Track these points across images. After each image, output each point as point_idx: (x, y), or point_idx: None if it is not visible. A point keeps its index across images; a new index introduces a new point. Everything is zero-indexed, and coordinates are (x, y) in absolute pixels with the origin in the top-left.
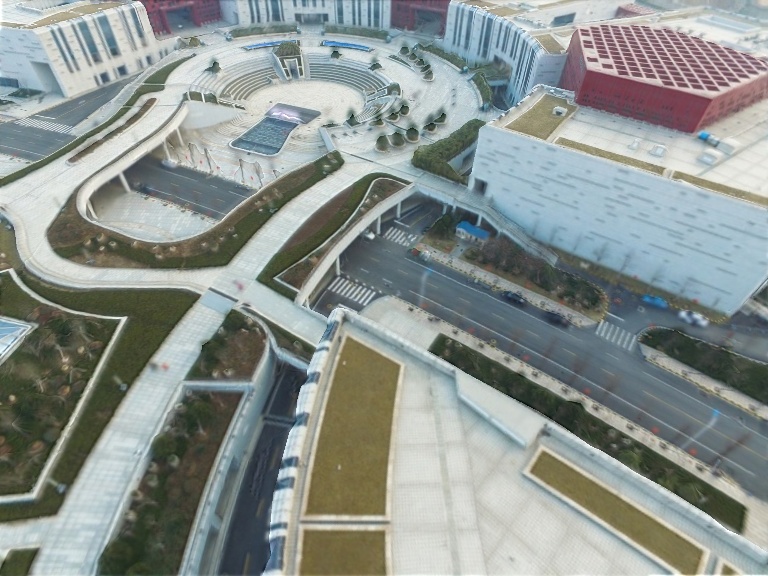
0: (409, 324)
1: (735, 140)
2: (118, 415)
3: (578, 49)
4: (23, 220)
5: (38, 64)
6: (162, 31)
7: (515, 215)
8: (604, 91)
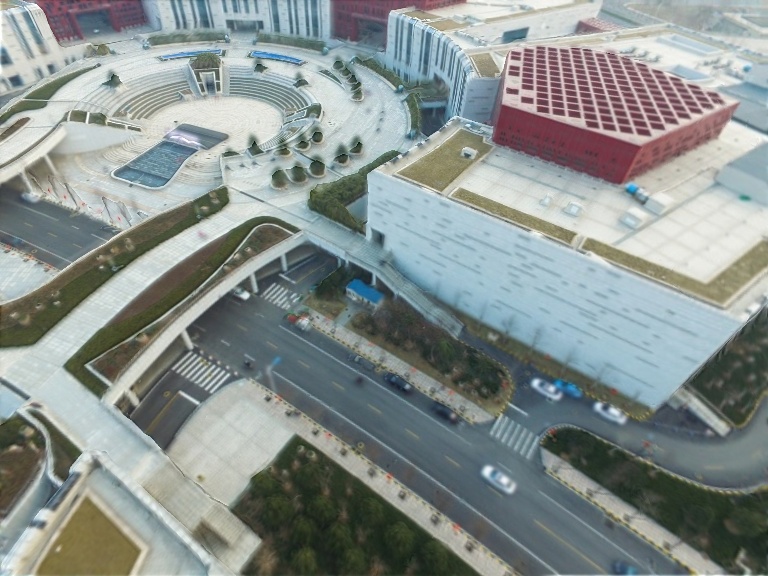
0: (260, 420)
1: (667, 196)
2: None
3: (503, 76)
4: None
5: None
6: (73, 36)
7: (416, 273)
8: (522, 130)
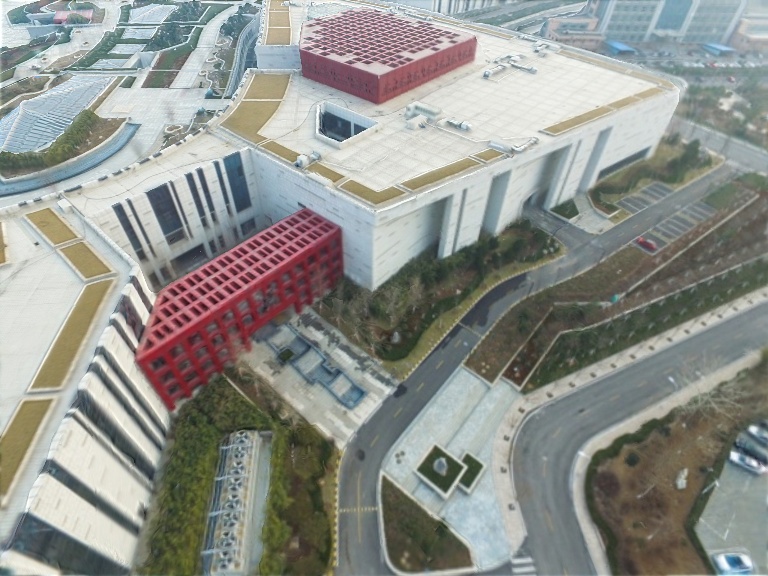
0: None
1: None
2: (216, 17)
3: None
4: None
5: None
6: None
7: None
8: None
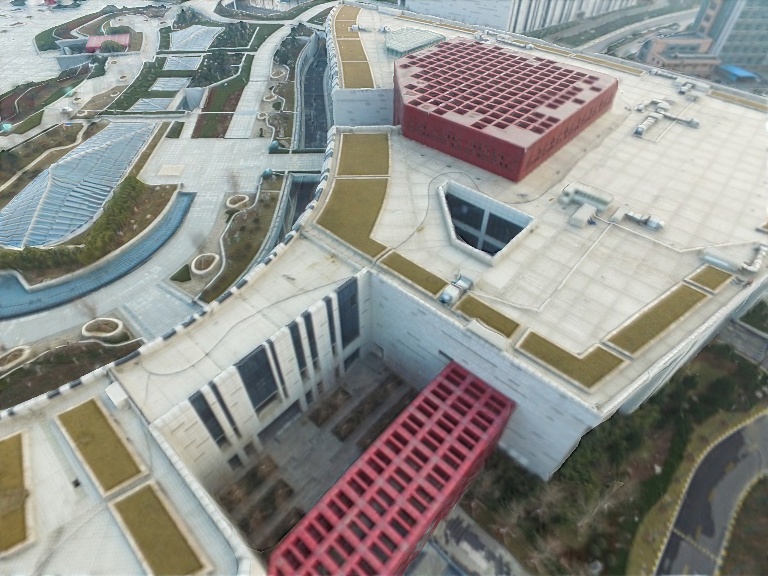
0: None
1: None
2: (267, 41)
3: None
4: (202, 9)
5: None
6: None
7: None
8: None
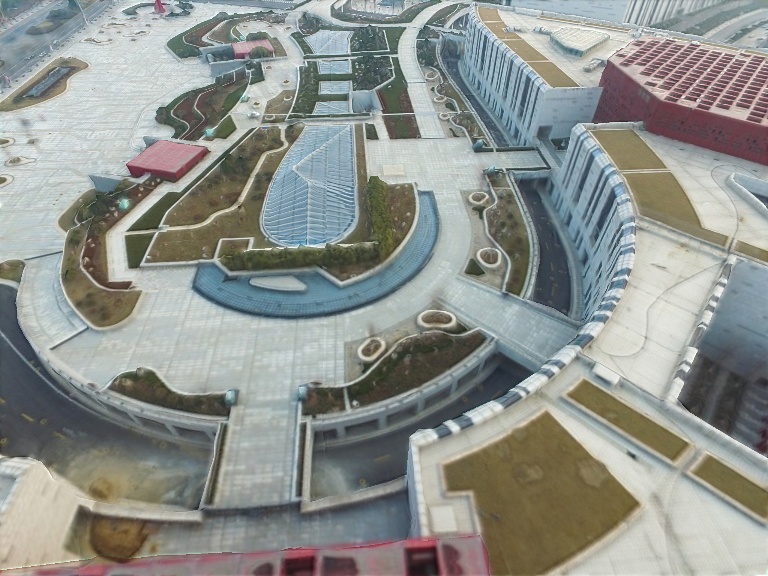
0: None
1: None
2: None
3: None
4: (318, 14)
5: None
6: None
7: None
8: None
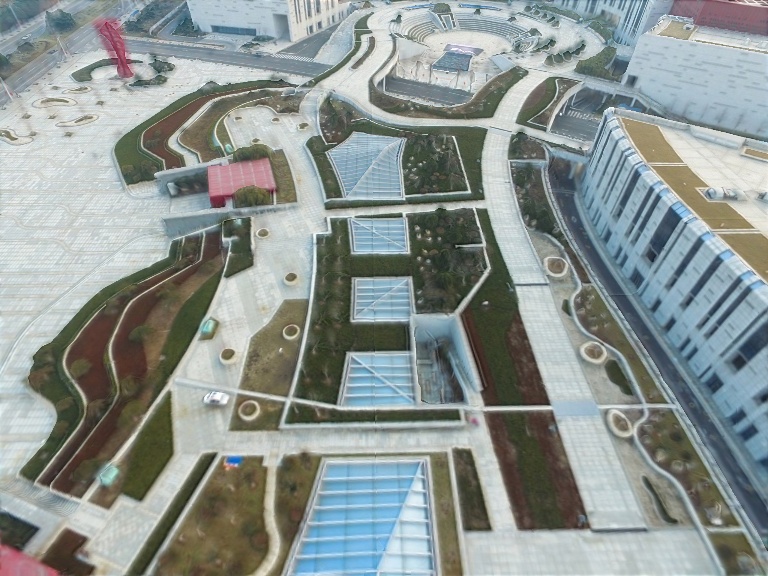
0: None
1: None
2: (484, 171)
3: None
4: (350, 96)
5: (279, 16)
6: None
7: (657, 99)
8: (718, 14)
